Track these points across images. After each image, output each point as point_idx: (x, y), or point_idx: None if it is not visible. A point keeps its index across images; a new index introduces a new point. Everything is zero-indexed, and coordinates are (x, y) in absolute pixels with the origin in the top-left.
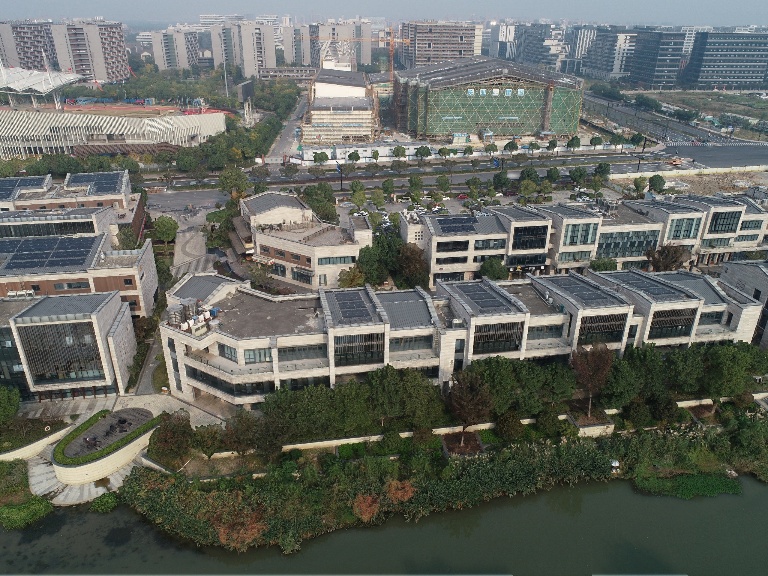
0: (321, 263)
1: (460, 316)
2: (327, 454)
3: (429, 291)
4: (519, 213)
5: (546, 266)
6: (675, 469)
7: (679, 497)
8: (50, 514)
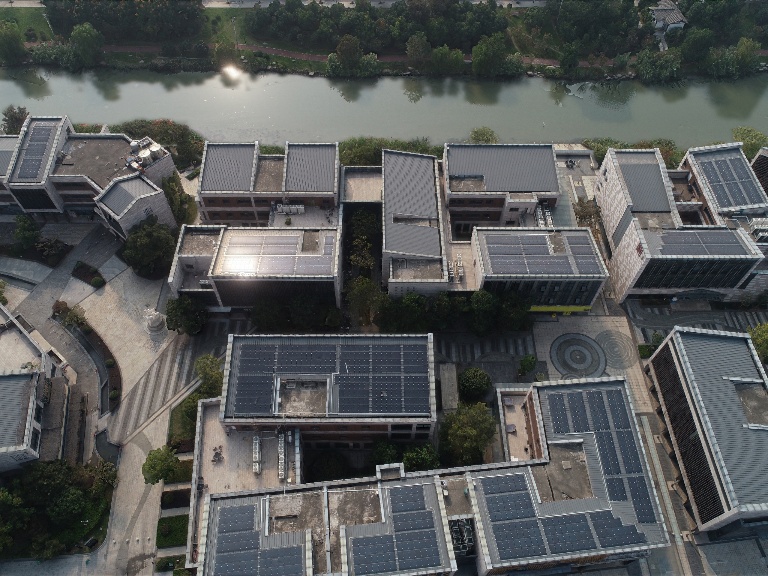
0: None
1: None
2: None
3: None
4: None
5: None
6: None
7: None
8: None
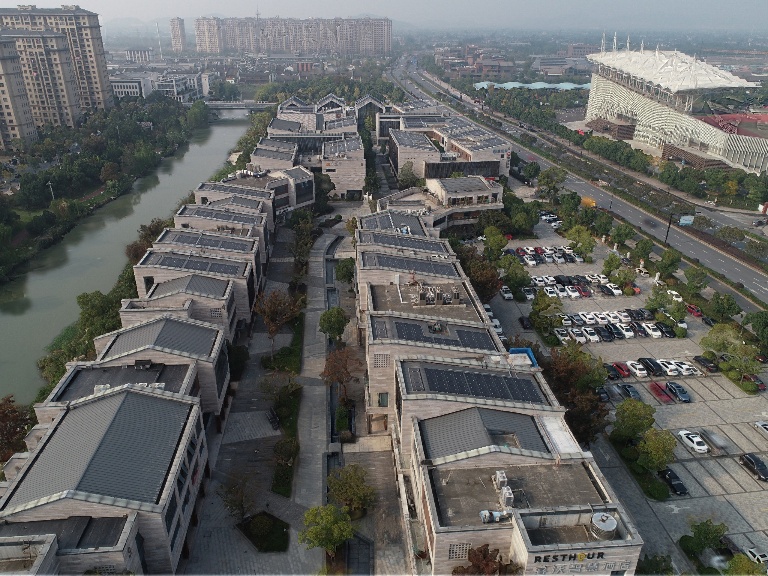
0: None
1: None
2: None
3: None
4: (401, 243)
5: (356, 295)
6: None
7: None
8: None
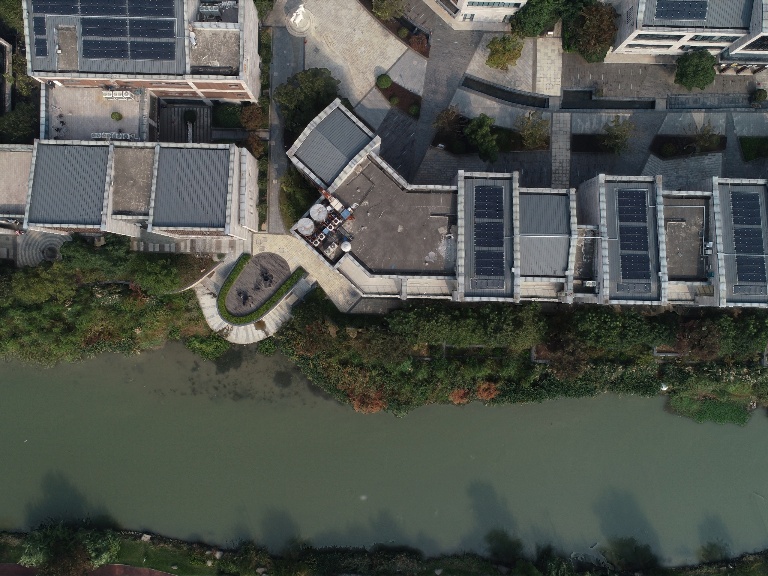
0: (471, 4)
1: (598, 271)
2: (436, 351)
3: (601, 63)
4: None
5: None
6: (711, 394)
7: (694, 420)
8: (229, 349)
